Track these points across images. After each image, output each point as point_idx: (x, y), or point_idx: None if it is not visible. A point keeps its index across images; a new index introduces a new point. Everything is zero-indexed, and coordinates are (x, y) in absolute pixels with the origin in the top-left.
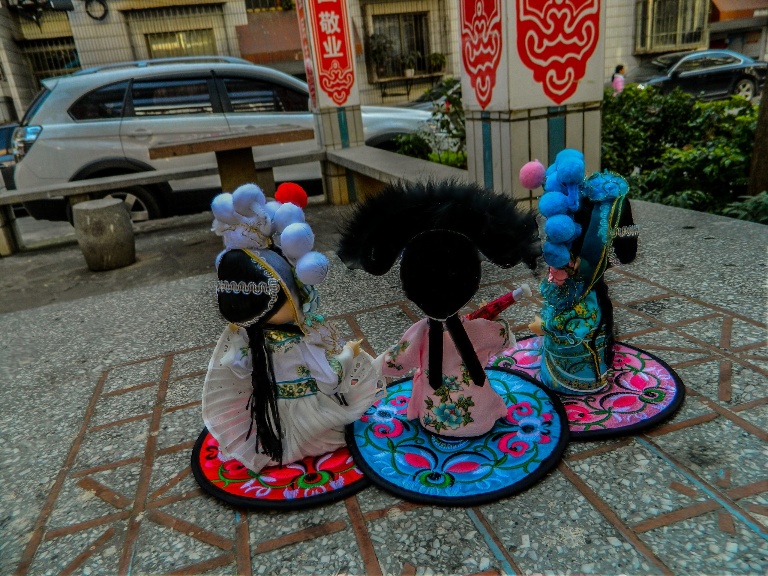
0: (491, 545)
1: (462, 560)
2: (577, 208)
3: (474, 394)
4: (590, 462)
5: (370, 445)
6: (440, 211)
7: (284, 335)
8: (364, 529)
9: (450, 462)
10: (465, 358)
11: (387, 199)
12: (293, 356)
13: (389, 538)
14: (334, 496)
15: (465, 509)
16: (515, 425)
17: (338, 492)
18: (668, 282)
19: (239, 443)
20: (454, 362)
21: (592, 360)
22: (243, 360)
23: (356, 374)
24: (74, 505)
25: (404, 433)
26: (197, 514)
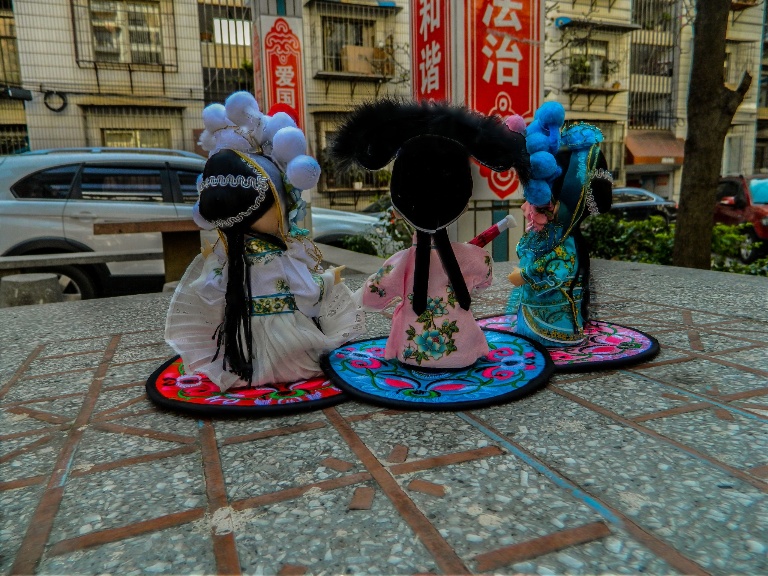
0: (487, 432)
1: (458, 442)
2: (558, 148)
3: (459, 318)
4: (578, 384)
5: (348, 370)
6: (435, 120)
7: (265, 247)
8: (346, 426)
9: (434, 384)
10: (451, 278)
11: (383, 106)
12: (273, 268)
13: (375, 431)
14: (311, 404)
15: (455, 413)
16: (498, 361)
17: (315, 401)
18: (625, 294)
19: (204, 364)
20: (440, 282)
21: (570, 310)
22: (216, 278)
23: (334, 305)
24: (1, 424)
25: (382, 367)
26: (152, 423)
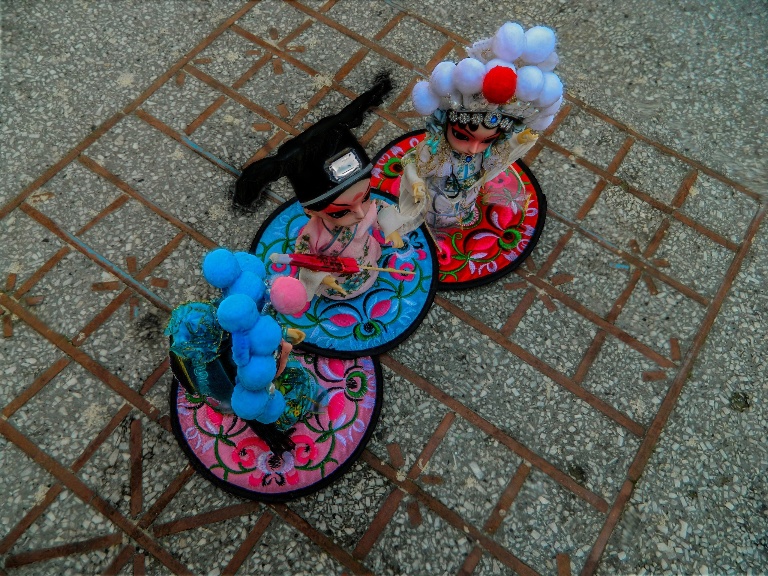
0: None
1: None
2: None
3: None
4: None
5: None
6: None
7: None
8: None
9: None
10: None
11: (366, 95)
12: None
13: None
14: None
15: None
16: None
17: None
18: None
19: None
20: None
21: None
22: None
23: None
24: None
25: None
26: None
